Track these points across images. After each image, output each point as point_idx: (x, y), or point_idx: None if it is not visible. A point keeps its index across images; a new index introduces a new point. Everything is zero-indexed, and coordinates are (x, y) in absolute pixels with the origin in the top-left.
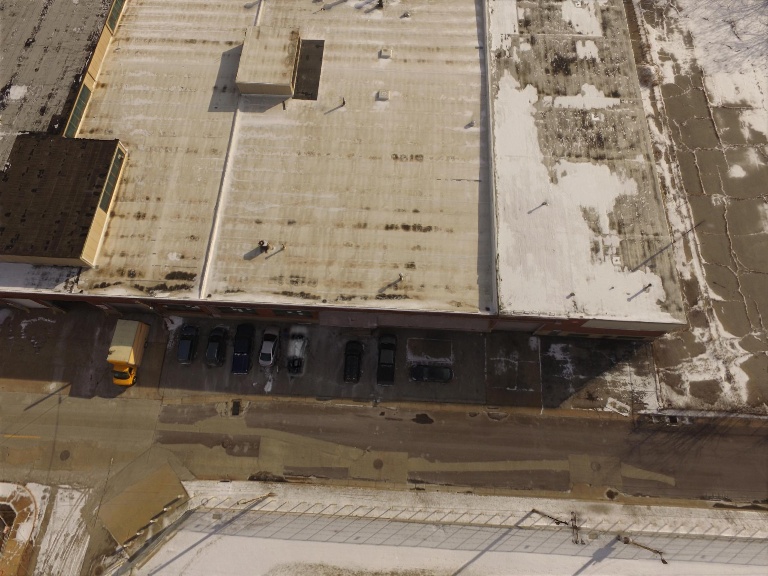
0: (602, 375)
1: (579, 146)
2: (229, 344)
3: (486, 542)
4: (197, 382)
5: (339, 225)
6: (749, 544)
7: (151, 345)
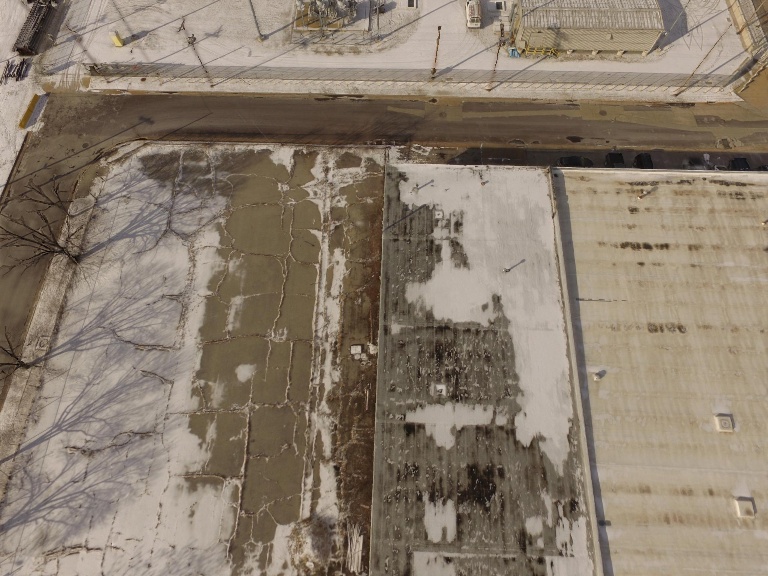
0: None
1: (465, 345)
2: None
3: (522, 74)
4: None
5: (717, 248)
6: (348, 78)
7: None
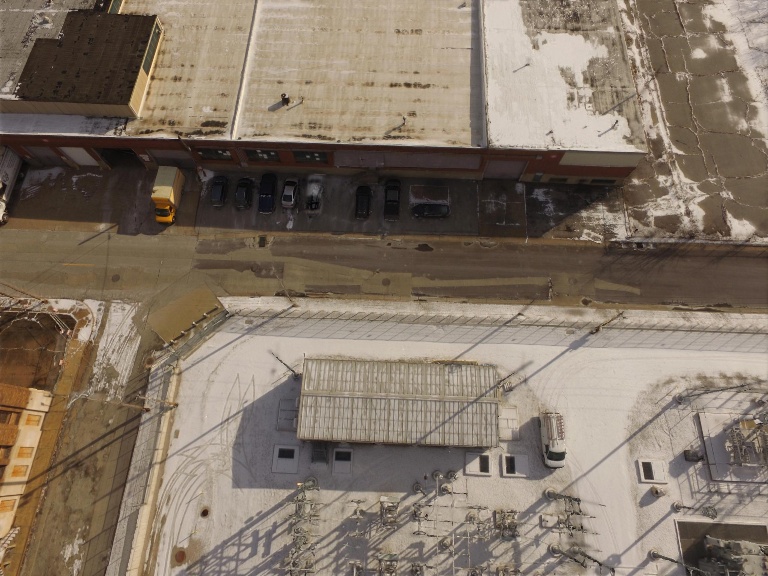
0: (579, 212)
1: (558, 21)
2: (255, 192)
3: (479, 337)
4: (228, 222)
5: (350, 84)
6: (702, 335)
7: (187, 193)
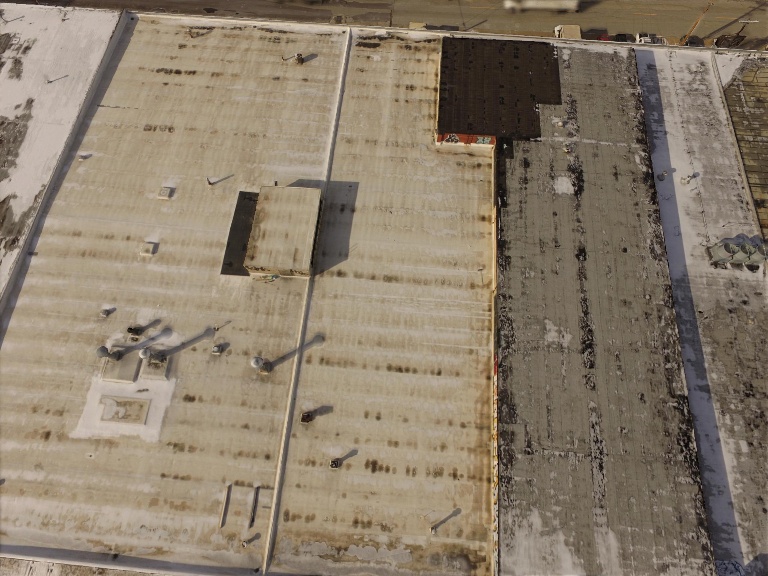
0: None
1: None
2: None
3: None
4: None
5: (235, 76)
6: None
7: None
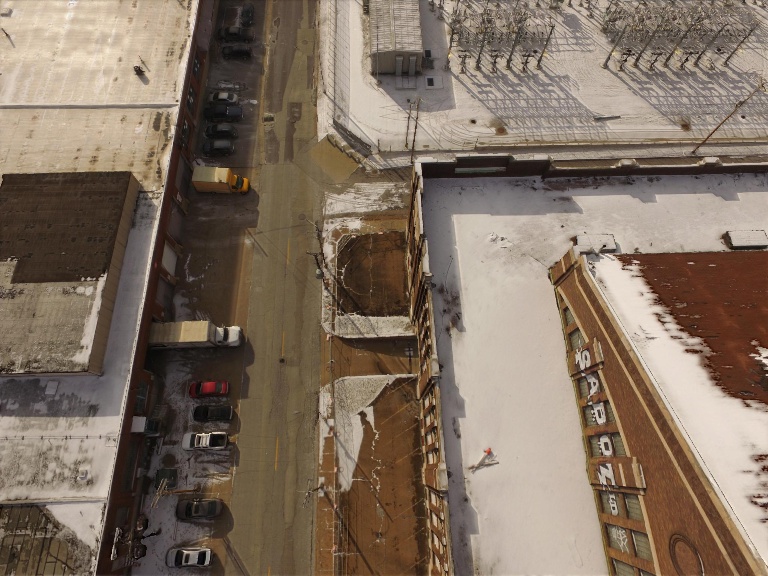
0: None
1: None
2: None
3: None
4: (248, 144)
5: (127, 32)
6: None
7: None
